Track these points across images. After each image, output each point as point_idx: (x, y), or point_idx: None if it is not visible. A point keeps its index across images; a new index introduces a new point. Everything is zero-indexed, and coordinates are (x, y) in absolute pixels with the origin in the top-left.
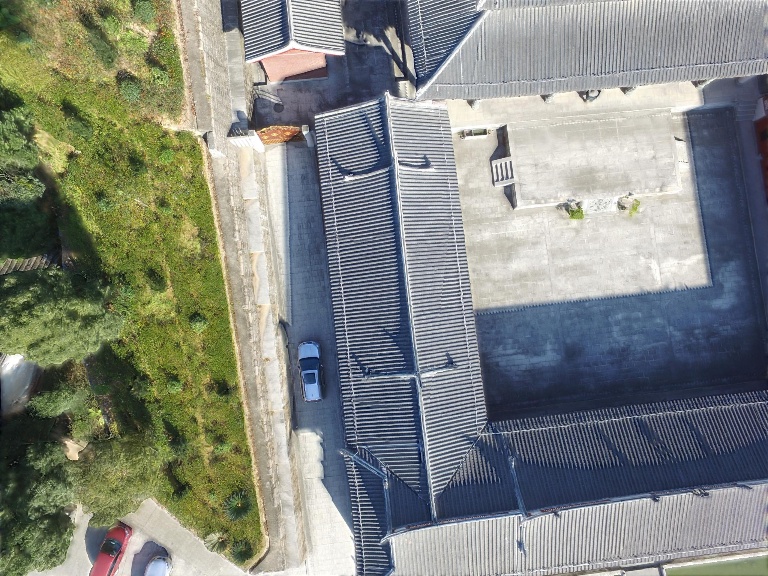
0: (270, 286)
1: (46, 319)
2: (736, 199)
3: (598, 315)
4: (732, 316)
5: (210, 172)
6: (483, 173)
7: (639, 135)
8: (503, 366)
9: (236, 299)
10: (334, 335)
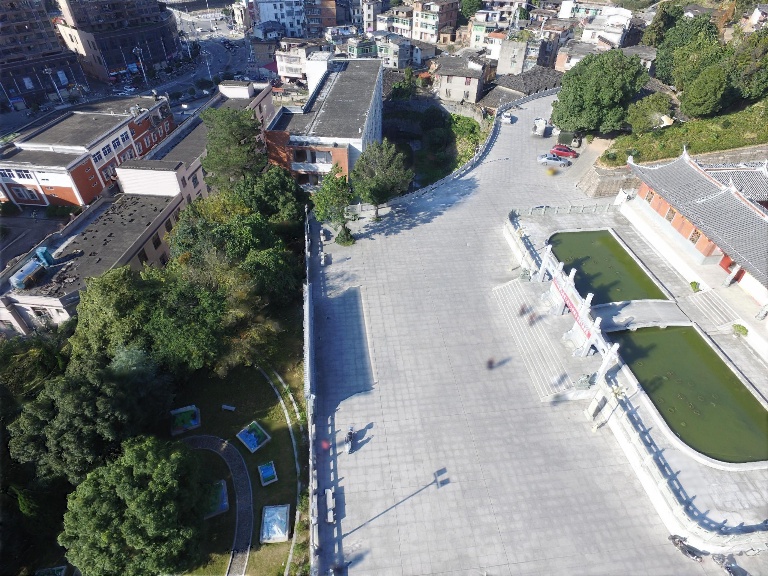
0: None
1: (721, 77)
2: None
3: None
4: None
5: None
6: None
7: None
8: None
9: None
10: None
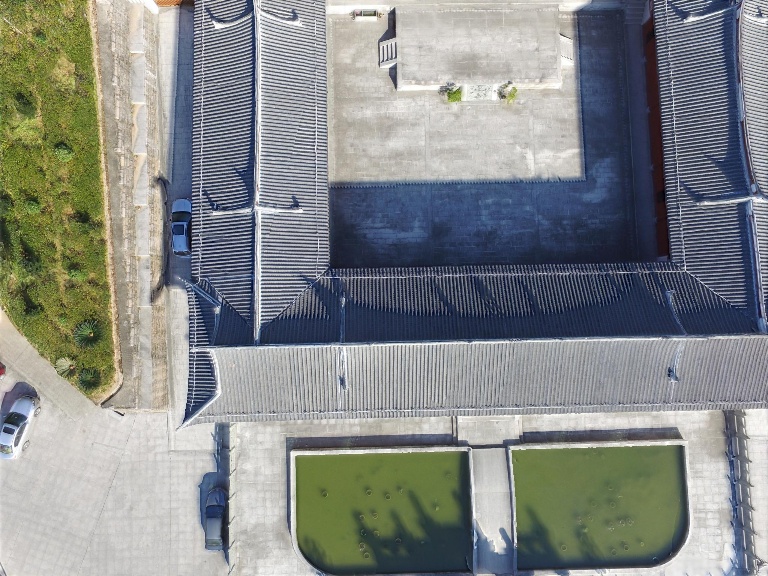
0: (149, 139)
1: None
2: (618, 99)
3: (469, 198)
4: (602, 211)
5: (94, 17)
6: (370, 54)
7: (524, 27)
8: (370, 238)
9: (109, 141)
10: None
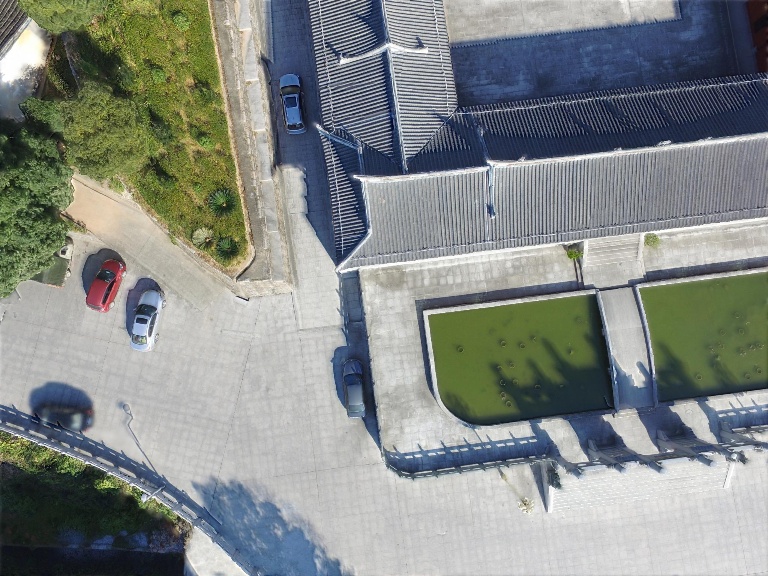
0: (251, 15)
1: None
2: None
3: (569, 47)
4: (701, 47)
5: None
6: None
7: None
8: (478, 95)
9: (218, 14)
10: (314, 67)
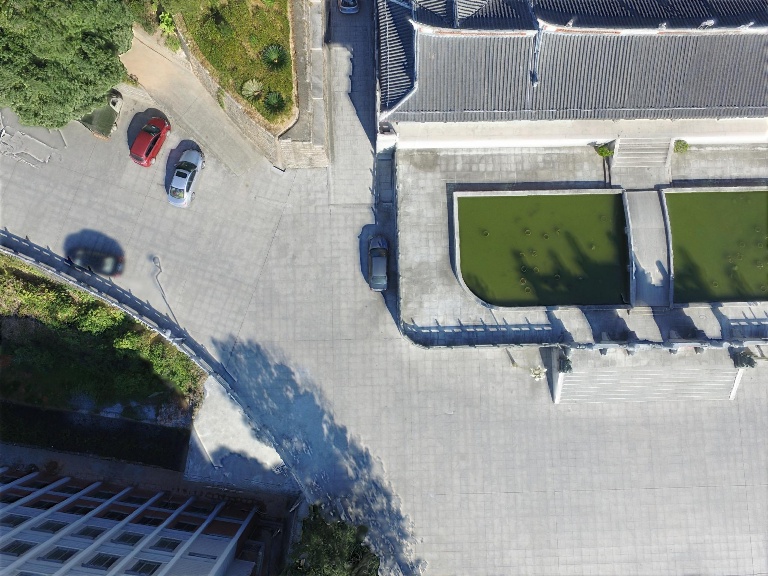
0: None
1: None
2: None
3: None
4: None
5: None
6: None
7: None
8: None
9: None
10: None
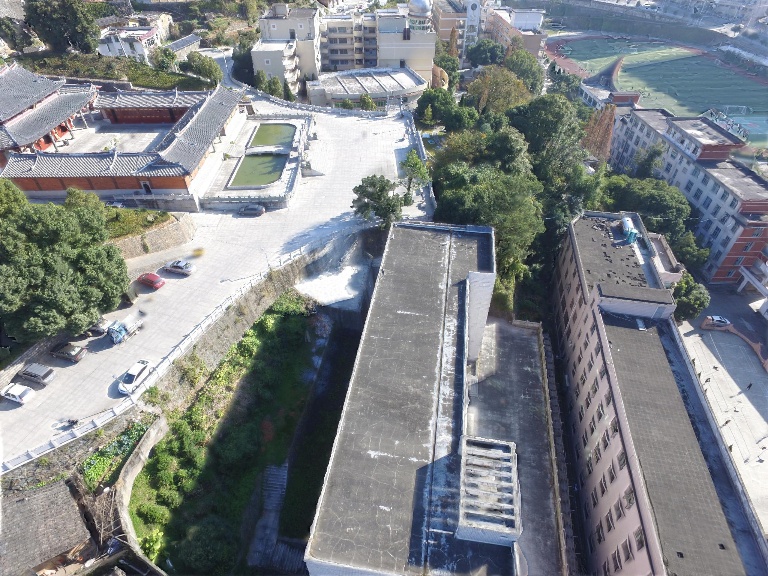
0: None
1: None
2: (134, 128)
3: None
4: None
5: None
6: None
7: None
8: None
9: None
10: None
